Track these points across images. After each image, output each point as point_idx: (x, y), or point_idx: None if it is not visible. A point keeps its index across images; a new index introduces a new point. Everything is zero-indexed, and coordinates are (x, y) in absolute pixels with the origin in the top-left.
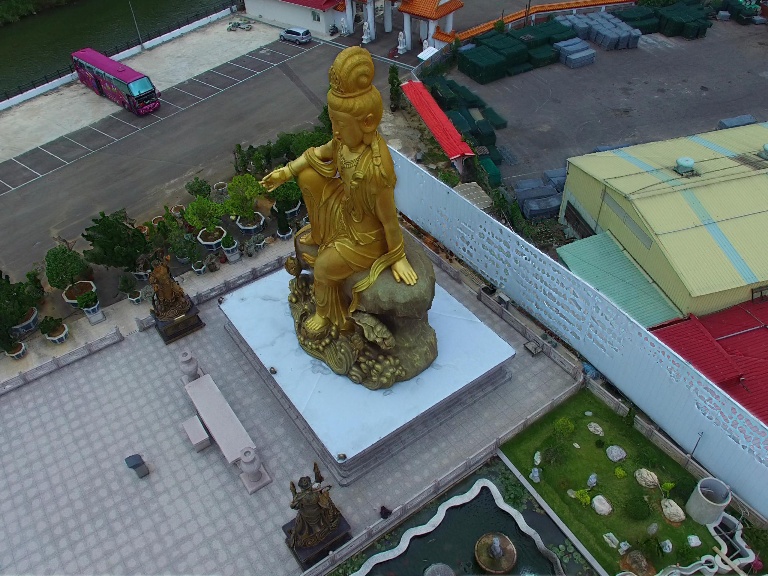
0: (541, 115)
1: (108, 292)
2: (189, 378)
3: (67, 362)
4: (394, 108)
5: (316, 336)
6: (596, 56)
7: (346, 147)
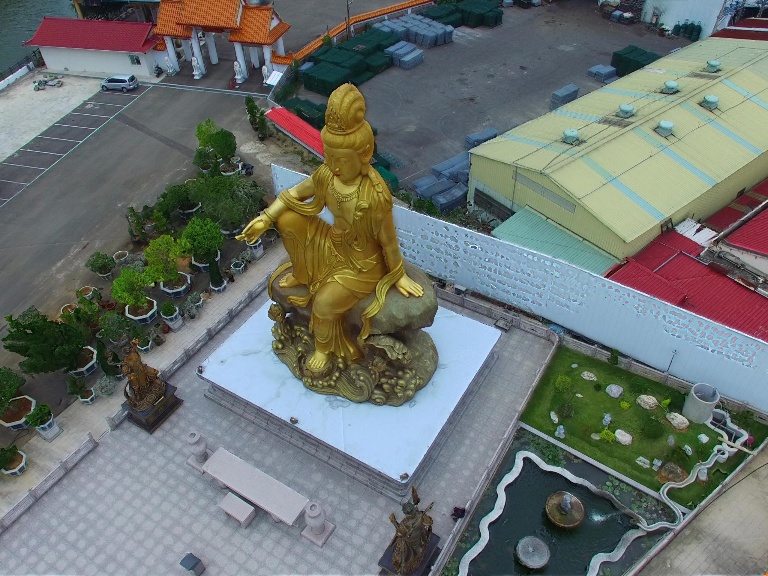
0: (402, 117)
1: (48, 401)
2: (198, 459)
3: (44, 490)
4: (262, 137)
5: (323, 373)
6: (424, 55)
7: (338, 182)
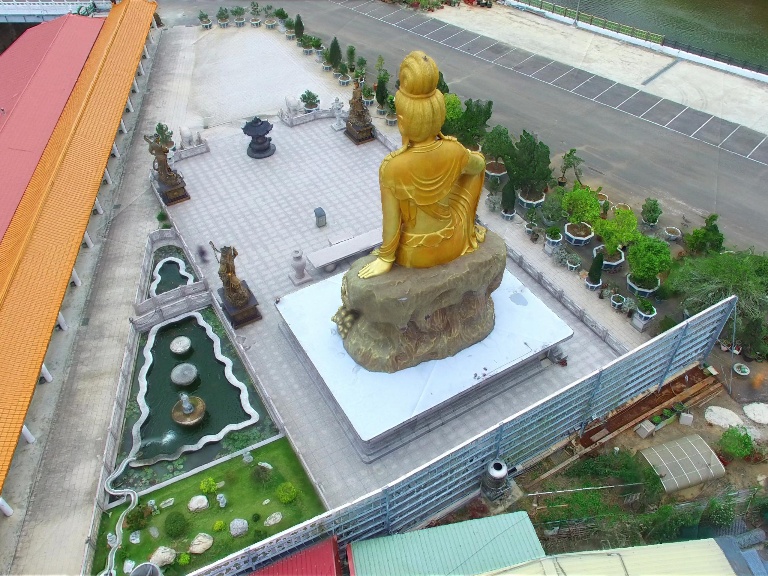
0: None
1: None
2: None
3: None
4: None
5: None
6: None
7: None
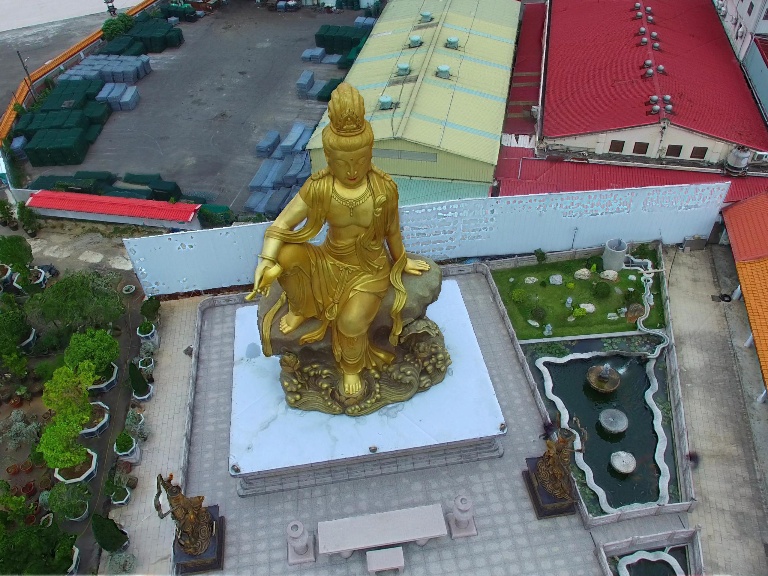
0: (171, 154)
1: None
2: (301, 551)
3: None
4: (33, 233)
5: (365, 393)
6: (139, 91)
7: (342, 190)
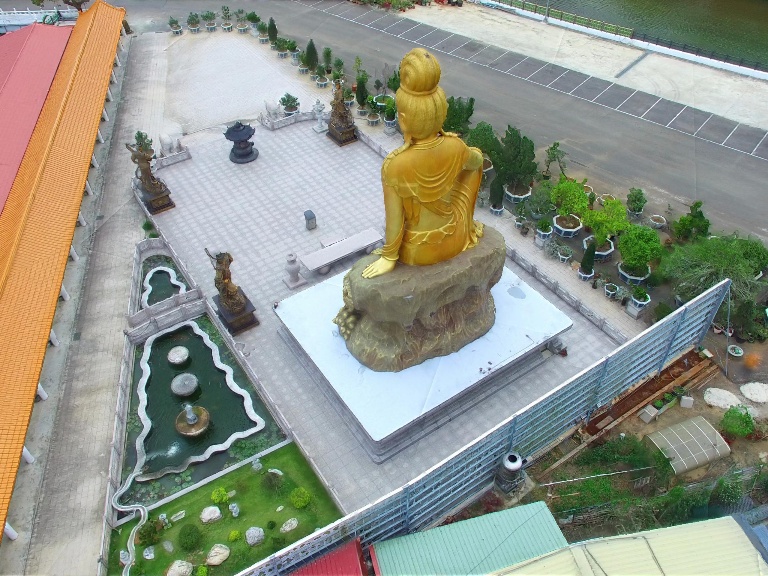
0: None
1: None
2: None
3: None
4: None
5: None
6: None
7: None
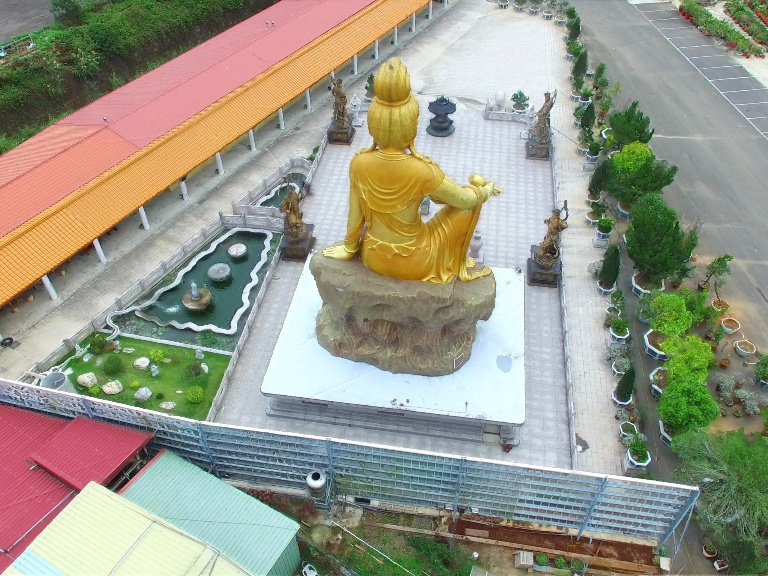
0: None
1: None
2: None
3: None
4: None
5: None
6: None
7: None
